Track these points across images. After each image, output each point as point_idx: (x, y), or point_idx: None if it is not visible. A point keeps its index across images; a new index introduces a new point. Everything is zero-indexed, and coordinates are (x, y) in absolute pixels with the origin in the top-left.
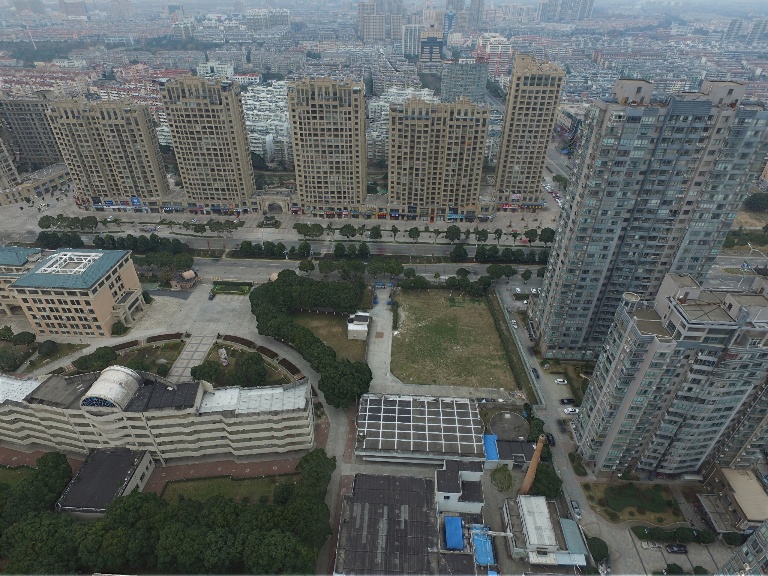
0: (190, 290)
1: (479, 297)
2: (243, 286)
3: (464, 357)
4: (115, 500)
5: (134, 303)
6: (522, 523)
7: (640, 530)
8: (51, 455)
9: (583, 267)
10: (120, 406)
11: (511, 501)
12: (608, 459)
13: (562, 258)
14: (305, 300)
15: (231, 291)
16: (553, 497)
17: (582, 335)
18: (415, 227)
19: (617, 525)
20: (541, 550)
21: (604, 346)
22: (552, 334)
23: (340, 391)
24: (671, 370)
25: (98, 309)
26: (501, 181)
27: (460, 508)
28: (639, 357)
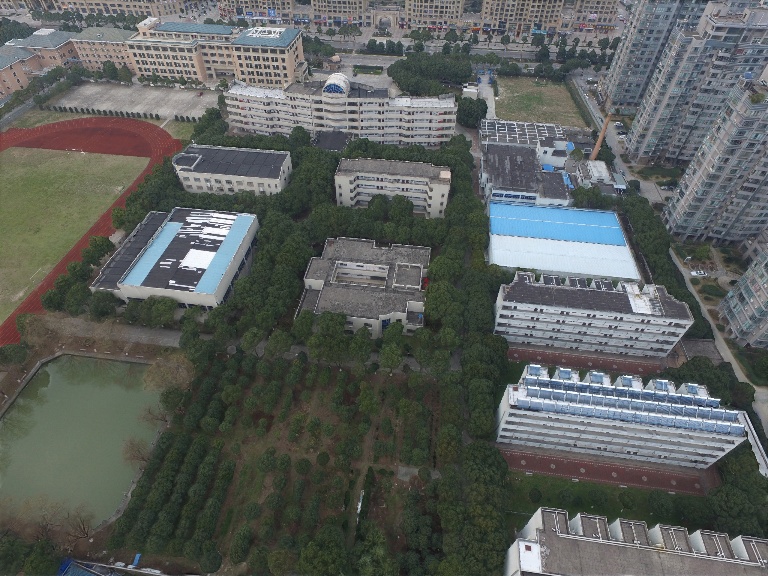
0: (337, 71)
1: (559, 82)
2: (376, 69)
3: (548, 112)
4: (351, 141)
5: (305, 71)
6: (589, 172)
7: (661, 182)
8: (301, 126)
9: (650, 27)
10: (346, 93)
11: (582, 165)
12: (647, 146)
13: (635, 23)
14: (431, 71)
15: (368, 72)
16: (609, 164)
17: (639, 91)
18: (507, 34)
19: (647, 181)
20: (600, 181)
21: (658, 65)
22: (617, 90)
23: (469, 112)
24: (700, 65)
25: (289, 66)
26: (581, 2)
27: (552, 162)
28: (681, 57)
